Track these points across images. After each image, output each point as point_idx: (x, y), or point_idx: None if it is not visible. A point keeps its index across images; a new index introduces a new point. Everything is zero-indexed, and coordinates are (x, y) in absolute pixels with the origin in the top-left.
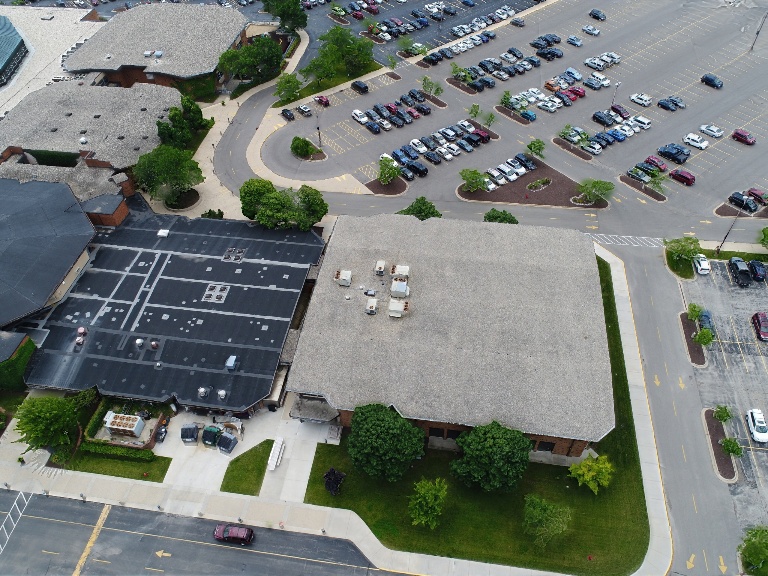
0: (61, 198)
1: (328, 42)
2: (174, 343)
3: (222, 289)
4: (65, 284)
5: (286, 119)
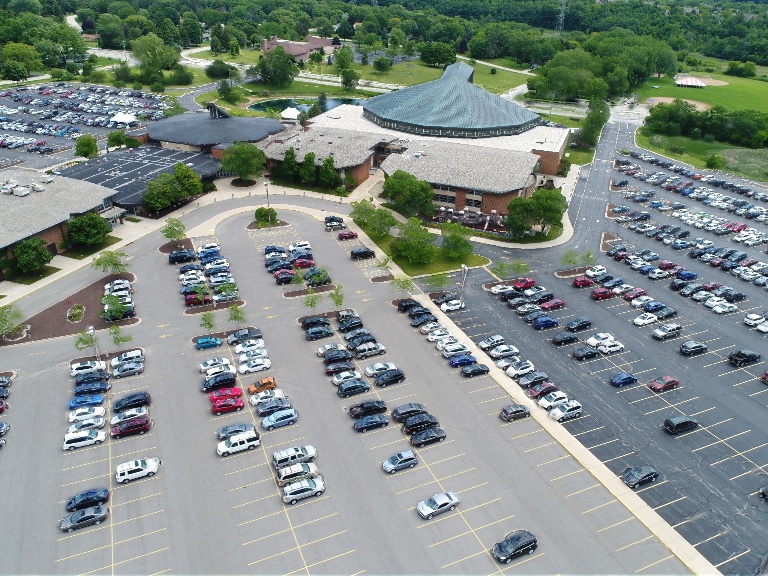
0: None
1: None
2: None
3: None
4: (169, 145)
5: None
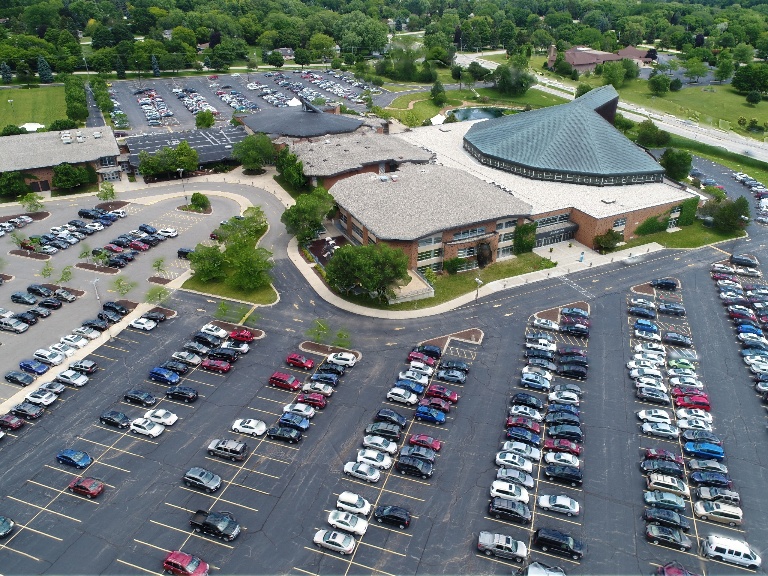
0: None
1: None
2: (178, 134)
3: None
4: None
5: None
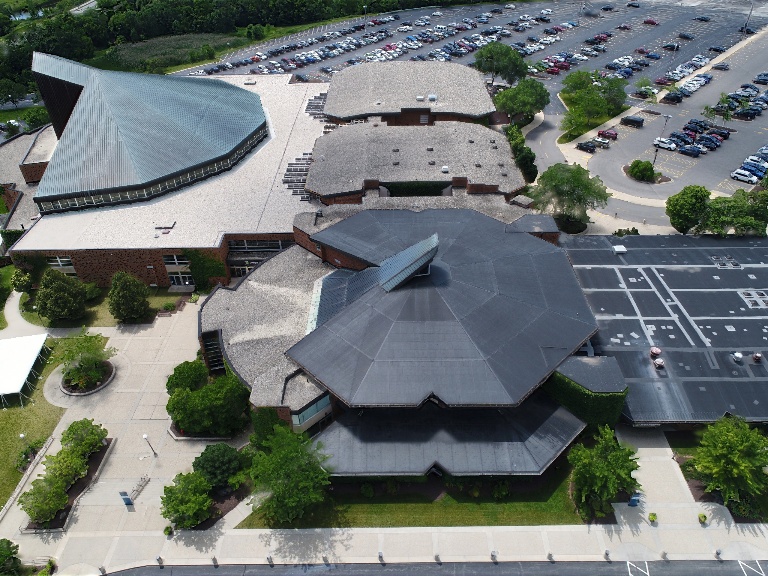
0: (485, 221)
1: (570, 86)
2: None
3: (760, 294)
4: None
5: (587, 152)
